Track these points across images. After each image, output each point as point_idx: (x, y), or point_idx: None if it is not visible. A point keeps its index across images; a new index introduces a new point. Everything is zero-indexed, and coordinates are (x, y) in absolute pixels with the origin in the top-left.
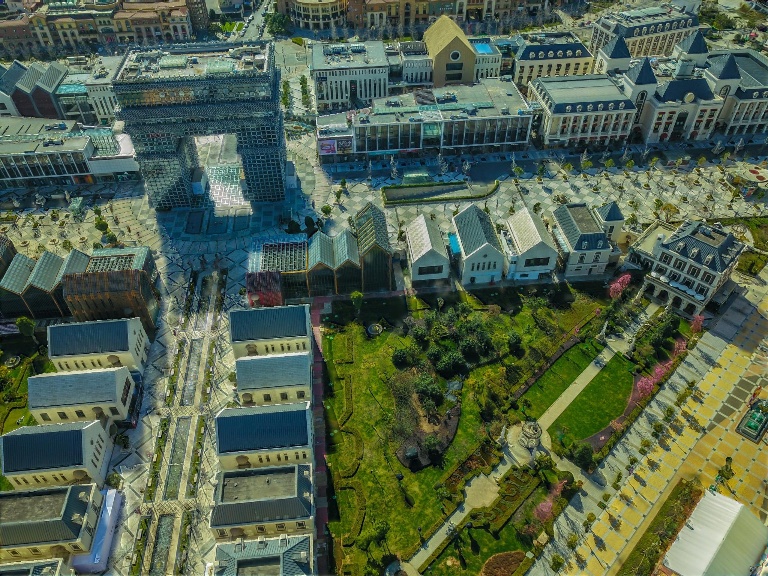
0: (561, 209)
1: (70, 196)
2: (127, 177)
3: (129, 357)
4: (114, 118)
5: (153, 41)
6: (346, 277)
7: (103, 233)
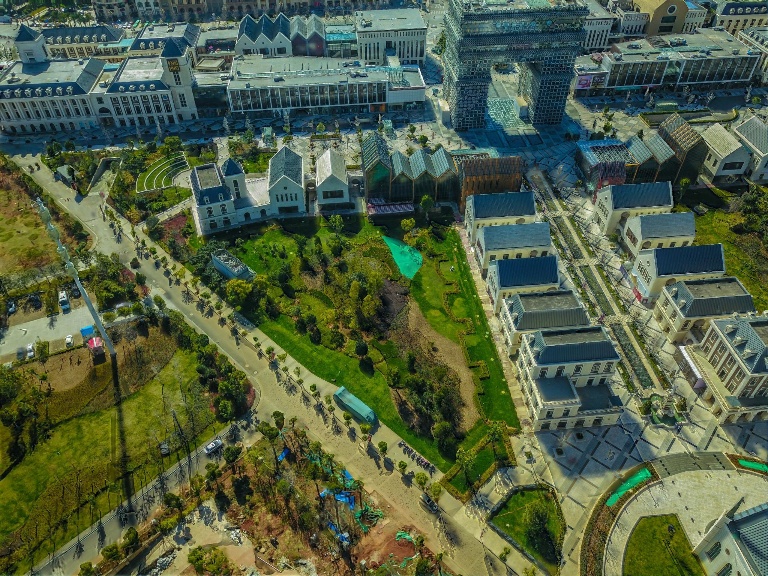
0: None
1: (373, 121)
2: (414, 107)
3: (532, 221)
4: (372, 63)
5: (366, 3)
6: (666, 171)
7: (423, 146)
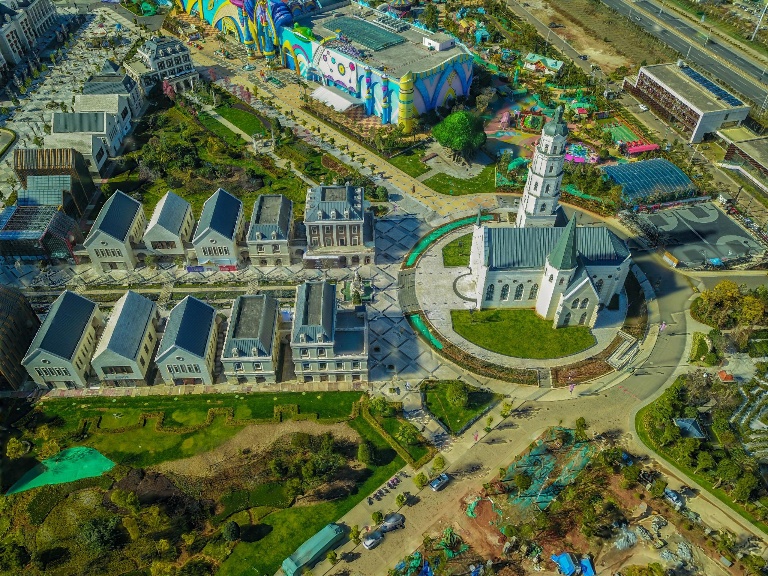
0: (87, 87)
1: None
2: None
3: (98, 312)
4: None
5: None
6: (77, 195)
7: None
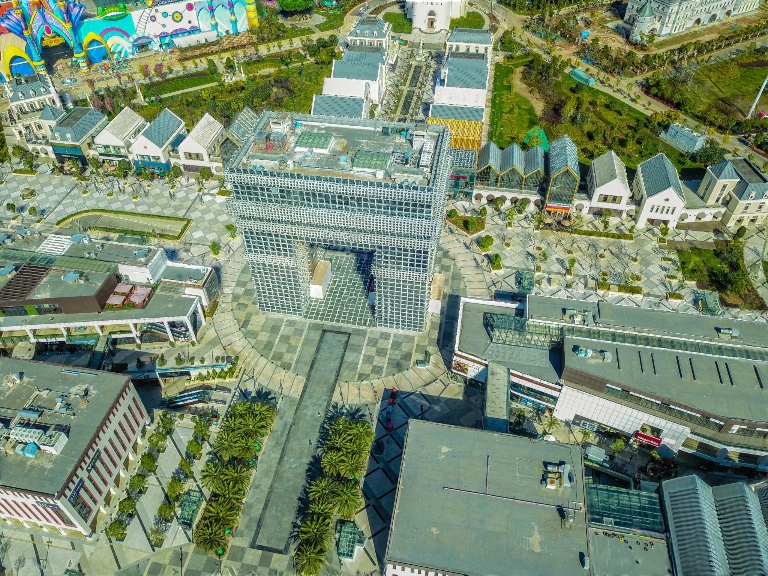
0: (76, 131)
1: None
2: None
3: None
4: None
5: None
6: None
7: None
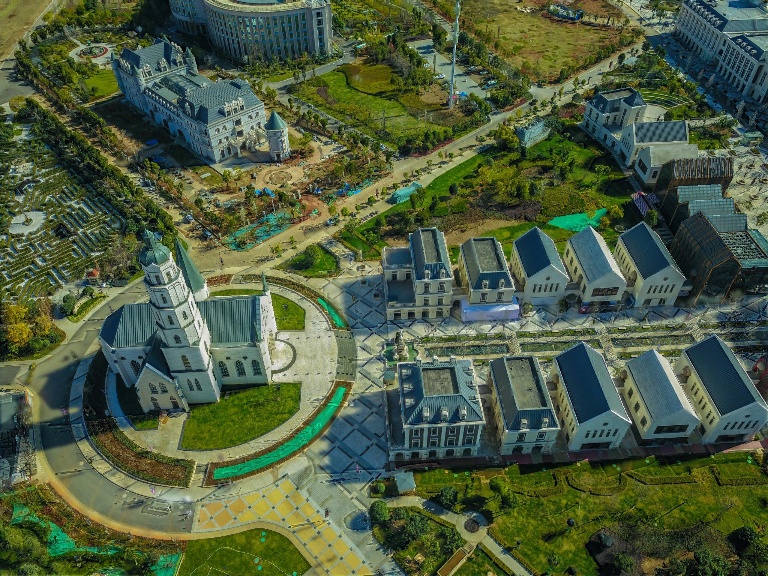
0: None
1: None
2: None
3: (641, 285)
4: None
5: None
6: None
7: None
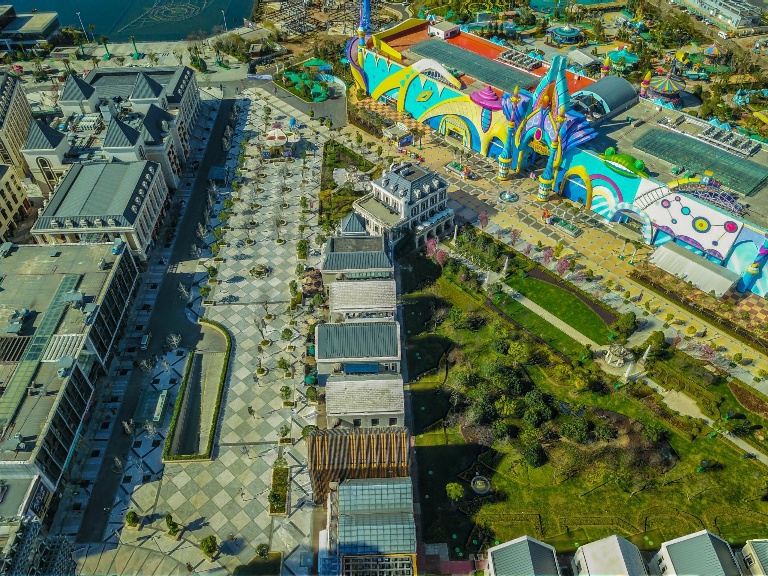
0: (331, 259)
1: None
2: None
3: None
4: None
5: None
6: None
7: None
